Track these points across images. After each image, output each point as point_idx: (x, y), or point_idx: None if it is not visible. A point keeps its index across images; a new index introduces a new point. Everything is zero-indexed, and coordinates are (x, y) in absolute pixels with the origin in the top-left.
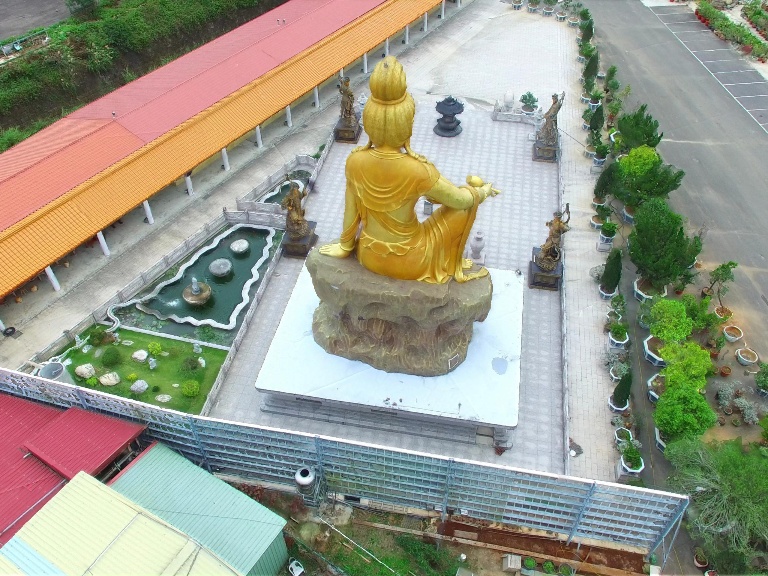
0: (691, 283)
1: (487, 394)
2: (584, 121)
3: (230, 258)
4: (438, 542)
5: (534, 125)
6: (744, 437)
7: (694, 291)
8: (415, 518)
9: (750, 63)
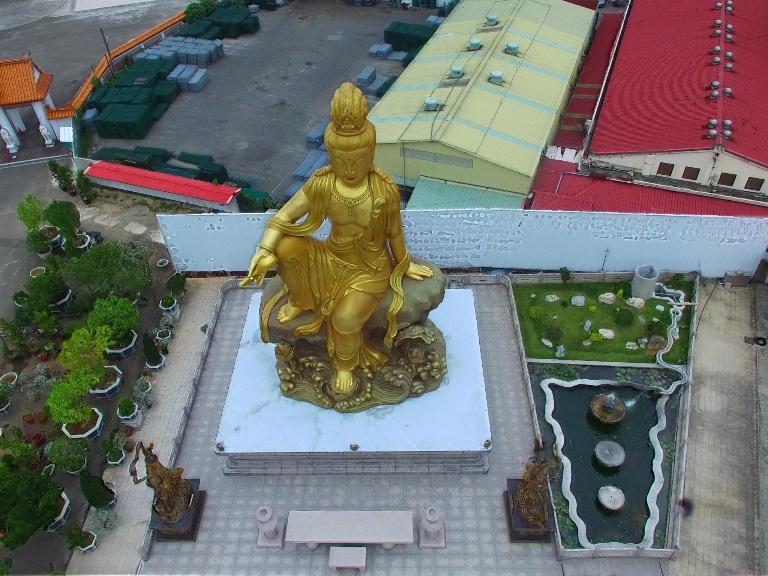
0: None
1: None
2: None
3: (615, 484)
4: None
5: None
6: (57, 364)
7: None
8: None
9: None
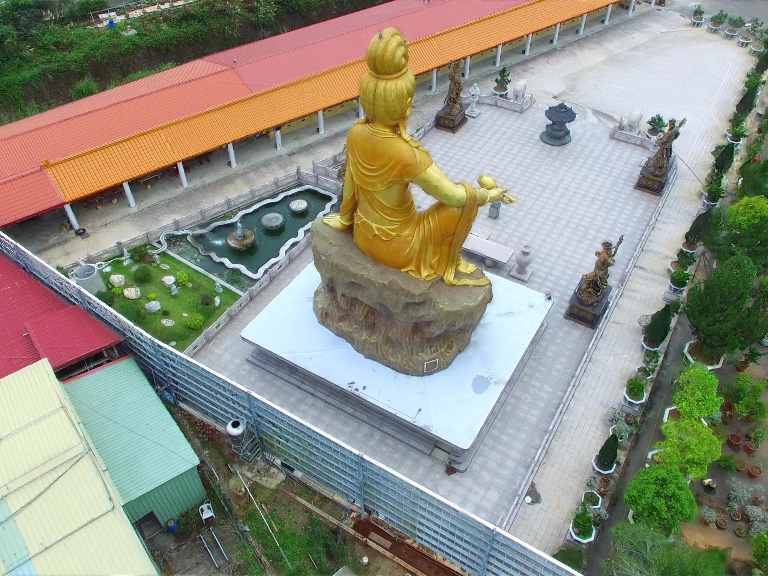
0: (755, 362)
1: (453, 408)
2: (714, 158)
3: (286, 215)
4: (348, 536)
5: None
6: (742, 551)
7: (761, 373)
8: (340, 506)
9: None
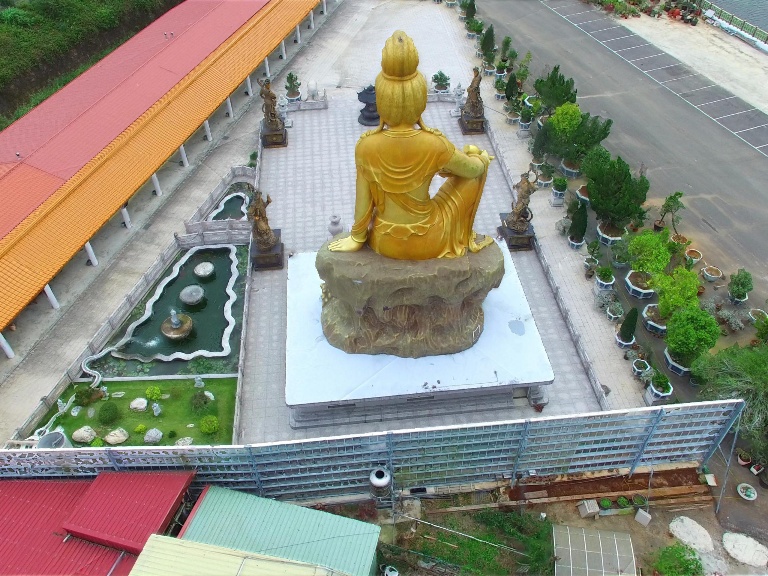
0: (646, 219)
1: (517, 356)
2: (496, 91)
3: (197, 284)
4: (515, 509)
5: (452, 102)
6: None
7: (647, 226)
8: (483, 493)
9: (616, 20)
